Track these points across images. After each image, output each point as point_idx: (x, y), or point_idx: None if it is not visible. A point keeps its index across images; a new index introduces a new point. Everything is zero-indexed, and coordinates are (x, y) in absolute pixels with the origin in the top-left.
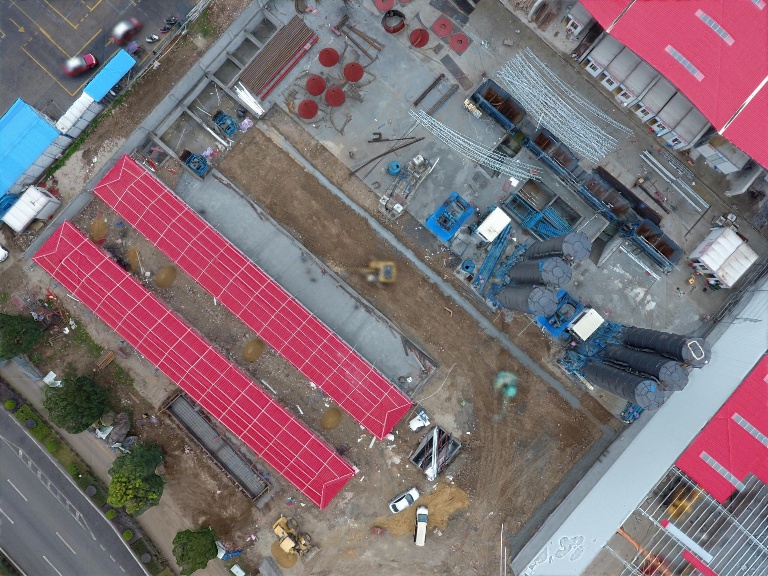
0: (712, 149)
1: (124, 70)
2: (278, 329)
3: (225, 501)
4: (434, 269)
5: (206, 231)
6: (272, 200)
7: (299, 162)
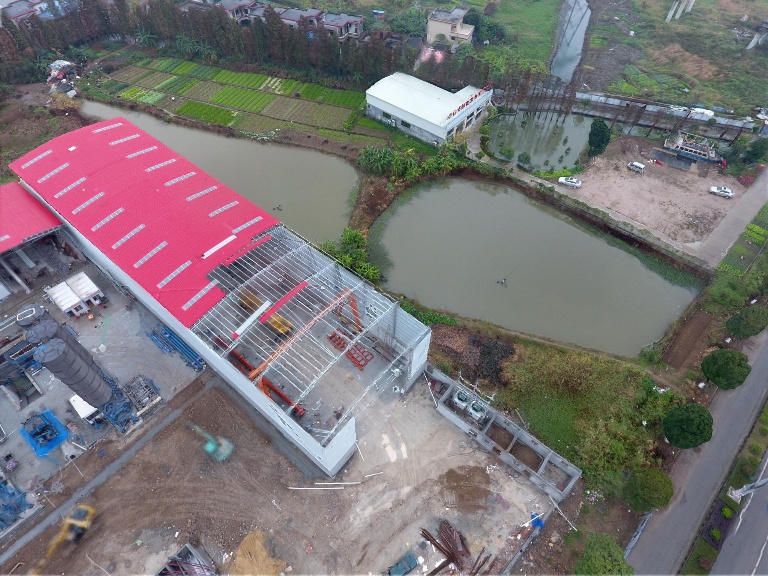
0: None
1: None
2: None
3: None
4: None
5: None
6: None
7: None
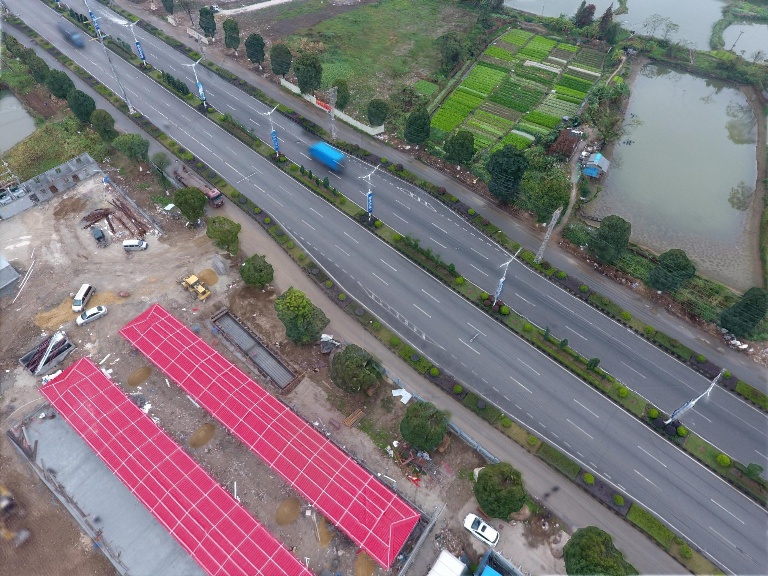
0: None
1: None
2: (155, 454)
3: (249, 309)
4: None
5: (216, 570)
6: None
7: None
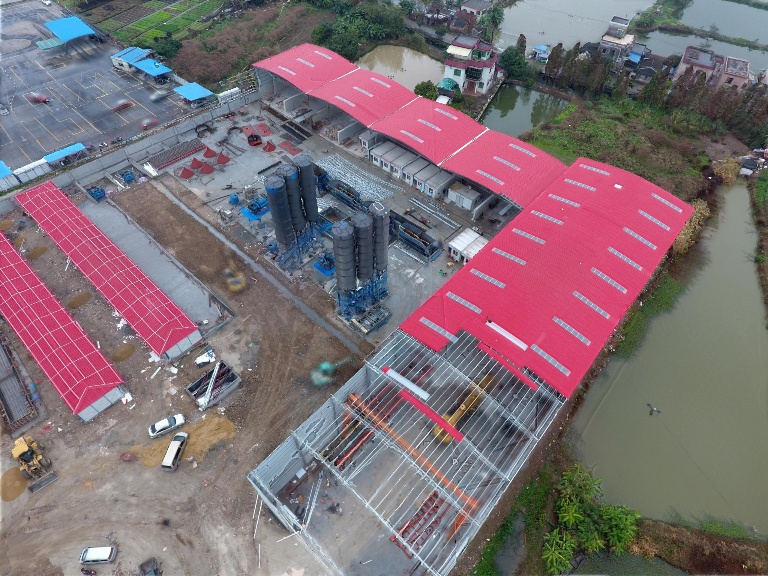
0: (453, 192)
1: (75, 151)
2: (105, 272)
3: None
4: (249, 255)
5: (81, 217)
6: (142, 215)
7: (171, 199)
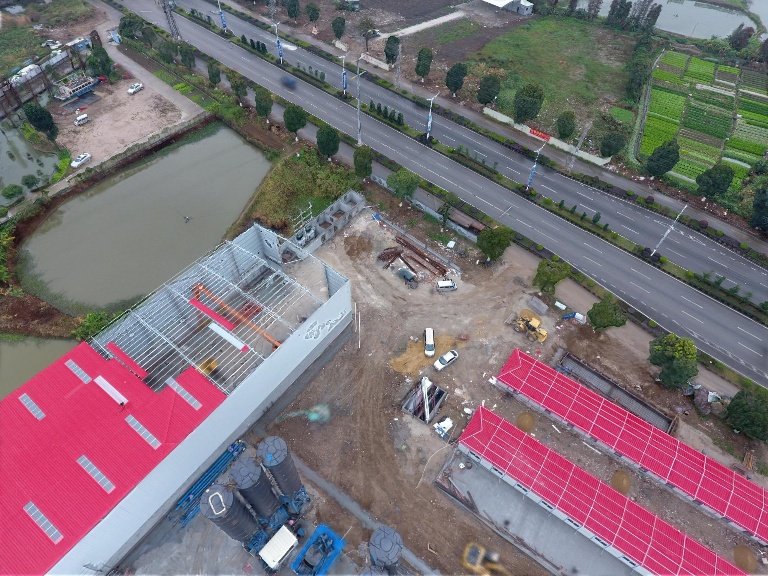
0: None
1: None
2: (611, 506)
3: (591, 351)
4: None
5: None
6: None
7: None
